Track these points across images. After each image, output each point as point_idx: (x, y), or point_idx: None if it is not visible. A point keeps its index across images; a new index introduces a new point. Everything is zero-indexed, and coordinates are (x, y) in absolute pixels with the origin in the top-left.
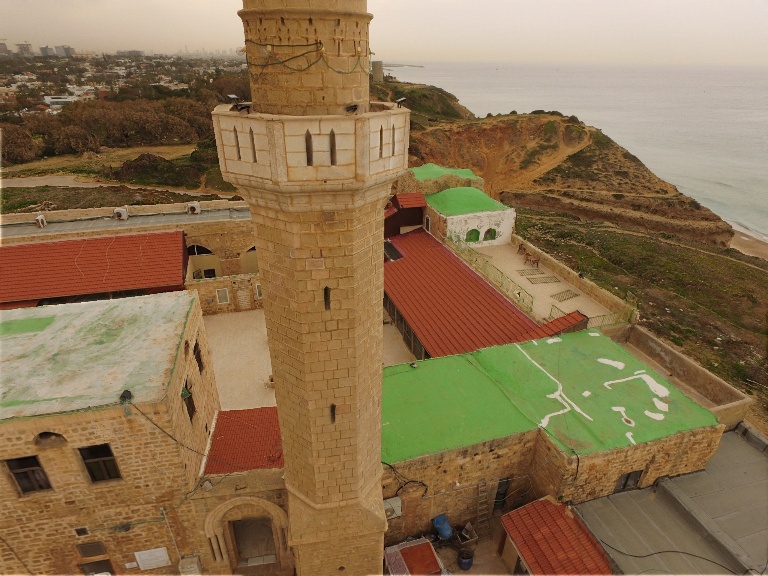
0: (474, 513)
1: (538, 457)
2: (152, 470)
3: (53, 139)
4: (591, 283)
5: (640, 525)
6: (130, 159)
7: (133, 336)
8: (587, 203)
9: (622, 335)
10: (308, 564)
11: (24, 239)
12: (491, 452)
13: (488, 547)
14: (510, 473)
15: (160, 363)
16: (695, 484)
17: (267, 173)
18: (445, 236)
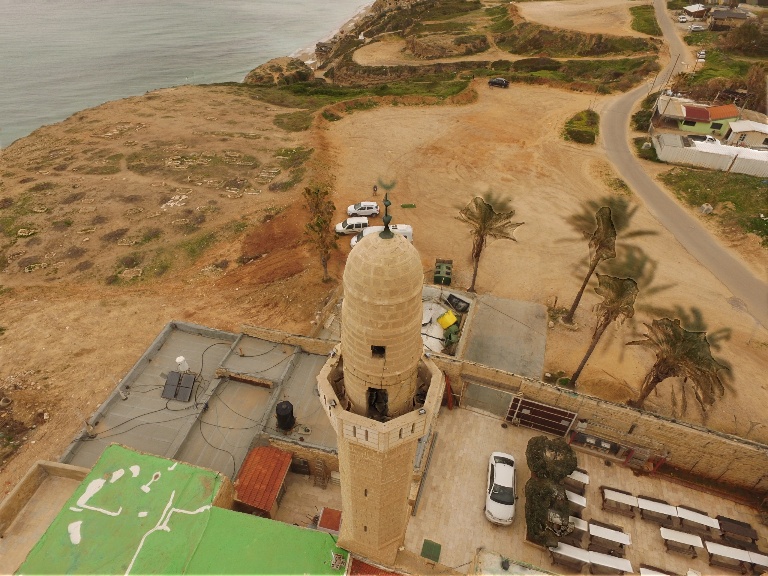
0: None
1: None
2: None
3: None
4: None
5: (206, 463)
6: None
7: None
8: None
9: None
10: None
11: None
12: None
13: None
14: None
15: None
16: None
17: None
18: None
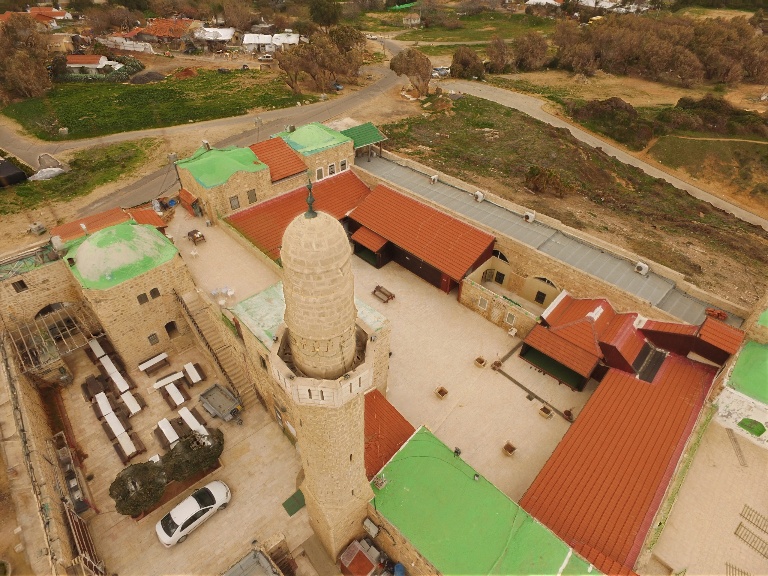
0: None
1: None
2: None
3: (562, 54)
4: None
5: None
6: (608, 93)
7: None
8: None
9: None
10: None
11: (410, 194)
12: (438, 575)
13: None
14: None
15: None
16: None
17: None
18: (710, 401)
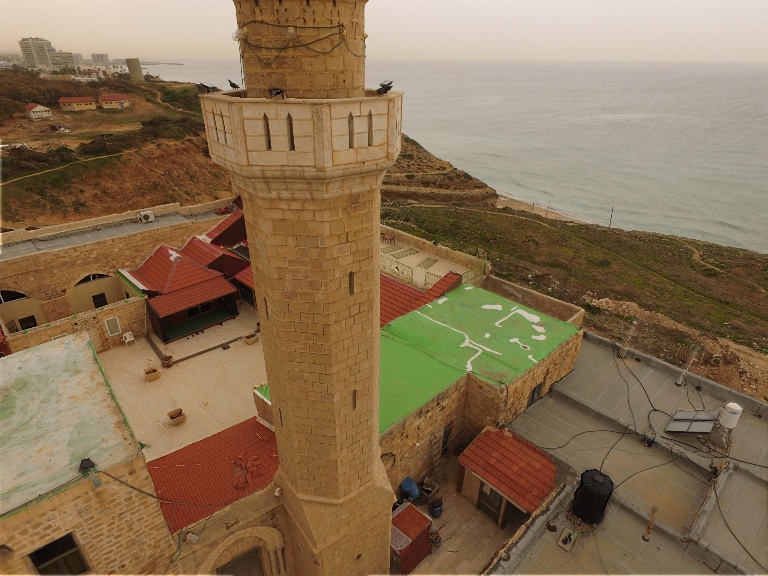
0: (428, 467)
1: (471, 398)
2: (129, 544)
3: None
4: (445, 248)
5: (553, 424)
6: None
7: (37, 401)
8: (387, 186)
9: (481, 285)
10: (330, 566)
11: None
12: (438, 406)
13: (447, 491)
14: (451, 420)
15: (102, 419)
16: (572, 382)
17: (308, 160)
18: None
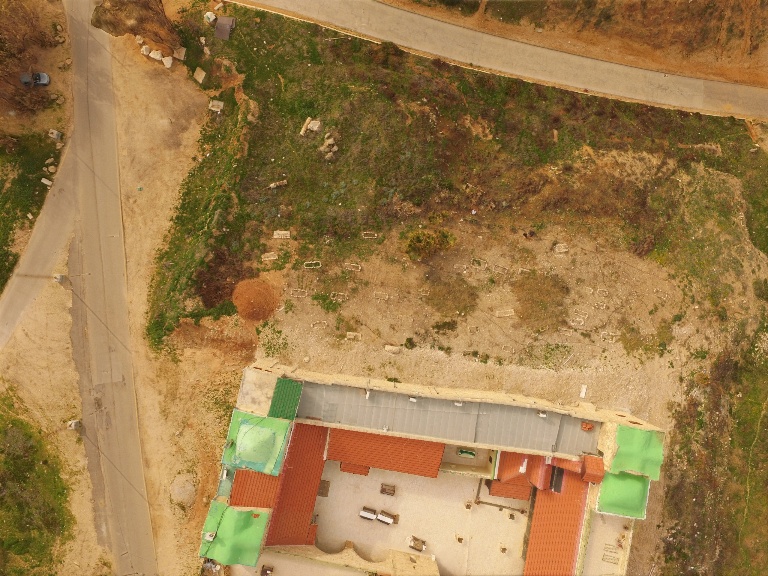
0: None
1: None
2: None
3: None
4: None
5: None
6: None
7: None
8: None
9: None
10: None
11: None
12: None
13: None
14: None
15: None
16: None
17: None
18: (590, 508)
